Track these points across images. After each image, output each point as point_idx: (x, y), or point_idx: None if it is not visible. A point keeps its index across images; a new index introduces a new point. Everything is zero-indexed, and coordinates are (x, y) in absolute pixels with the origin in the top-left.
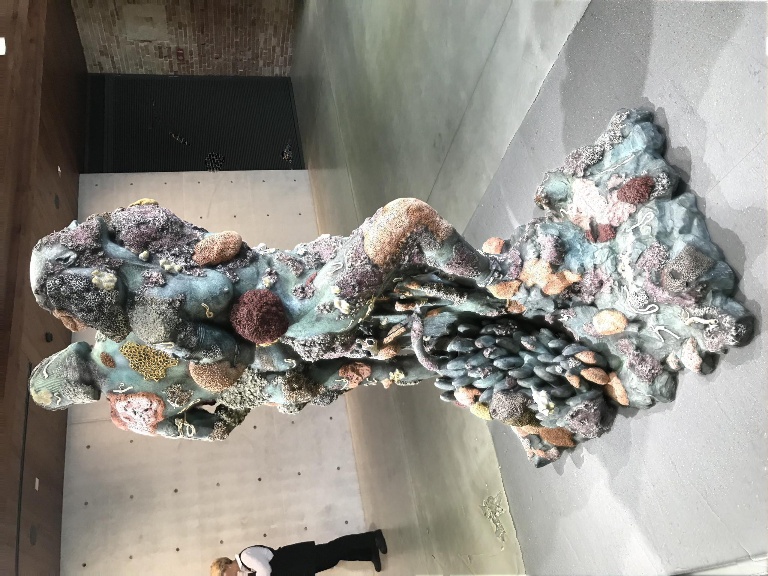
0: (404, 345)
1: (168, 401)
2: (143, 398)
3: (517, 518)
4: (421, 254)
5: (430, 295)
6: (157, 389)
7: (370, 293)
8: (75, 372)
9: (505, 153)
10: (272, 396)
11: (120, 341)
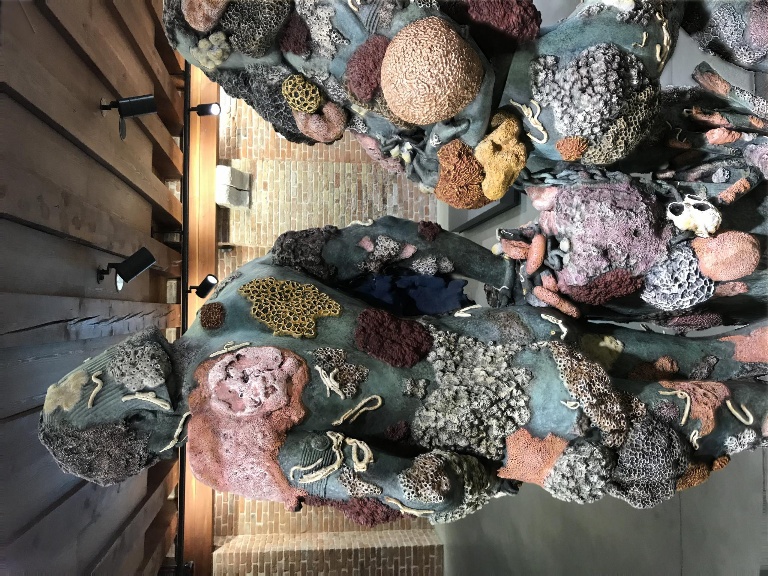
0: (764, 259)
1: (317, 370)
2: (268, 347)
3: None
4: (707, 27)
5: (757, 125)
6: (297, 348)
7: (656, 5)
8: (149, 329)
9: None
10: (535, 375)
11: (273, 8)
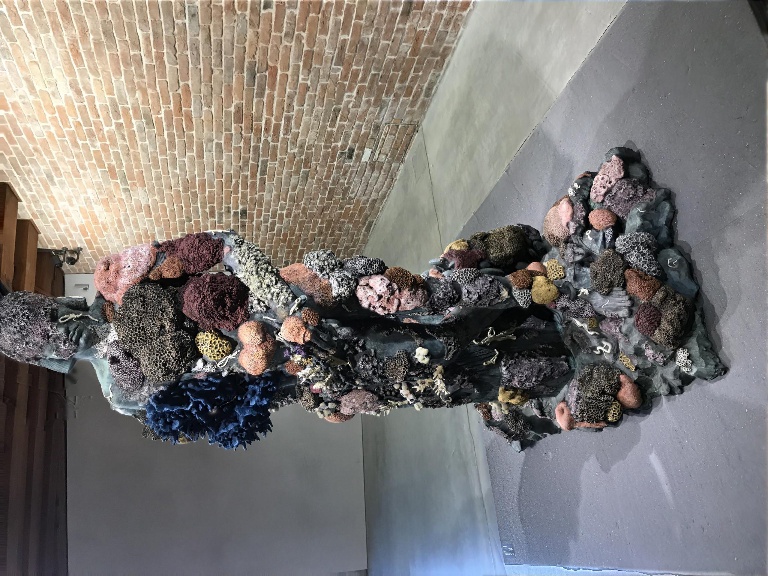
0: None
1: None
2: None
3: (729, 5)
4: None
5: None
6: None
7: None
8: None
9: (661, 571)
10: None
11: None
